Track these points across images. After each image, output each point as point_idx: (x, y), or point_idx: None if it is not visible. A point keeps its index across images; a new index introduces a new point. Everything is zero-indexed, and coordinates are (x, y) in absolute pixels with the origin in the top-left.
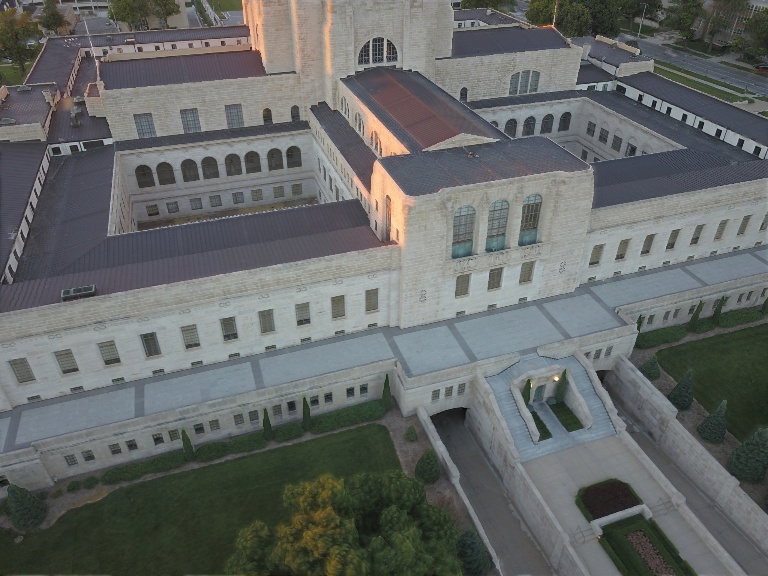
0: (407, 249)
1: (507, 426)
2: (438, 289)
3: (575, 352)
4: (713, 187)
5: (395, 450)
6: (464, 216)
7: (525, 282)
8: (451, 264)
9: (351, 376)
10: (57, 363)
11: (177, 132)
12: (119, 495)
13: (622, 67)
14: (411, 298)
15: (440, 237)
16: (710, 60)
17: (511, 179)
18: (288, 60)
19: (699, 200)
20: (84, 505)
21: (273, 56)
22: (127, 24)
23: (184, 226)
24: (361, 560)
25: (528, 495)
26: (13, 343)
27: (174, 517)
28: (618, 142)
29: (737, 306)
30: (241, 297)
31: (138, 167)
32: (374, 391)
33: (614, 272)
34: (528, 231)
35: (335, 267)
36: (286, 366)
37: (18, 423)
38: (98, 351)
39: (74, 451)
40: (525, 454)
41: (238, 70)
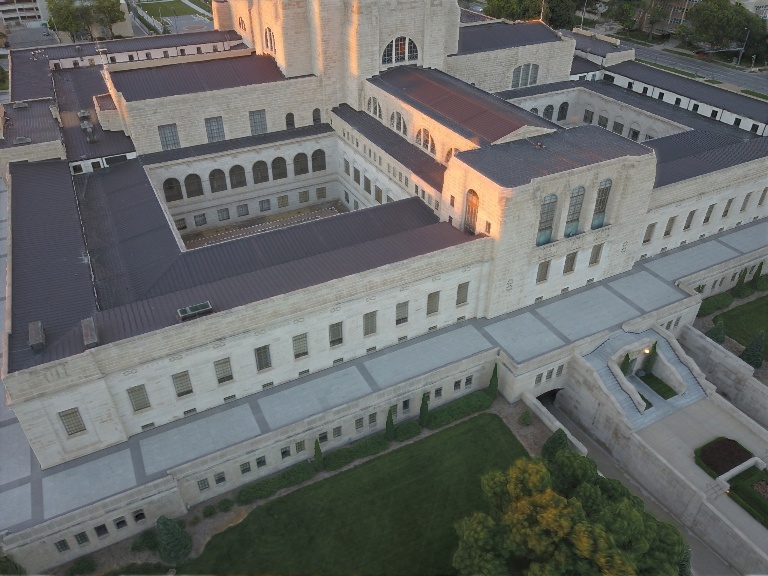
0: (501, 240)
1: (616, 400)
2: (523, 277)
3: (653, 325)
4: (742, 163)
5: (514, 436)
6: (547, 204)
7: (593, 264)
8: (536, 252)
9: (459, 369)
10: (173, 386)
11: (201, 142)
12: (260, 514)
13: (608, 57)
14: (499, 288)
15: (529, 226)
16: (653, 48)
17: (589, 166)
18: (306, 63)
19: (732, 175)
20: (227, 529)
21: (292, 59)
22: (69, 34)
23: (257, 236)
24: (606, 534)
25: (650, 462)
26: (135, 370)
27: (325, 528)
28: (619, 128)
29: (767, 270)
30: (351, 301)
31: (166, 180)
32: (477, 382)
33: (661, 248)
34: (597, 215)
35: (435, 263)
36: (393, 366)
37: (140, 453)
38: (214, 370)
39: (207, 475)
40: (635, 425)
41: (255, 75)
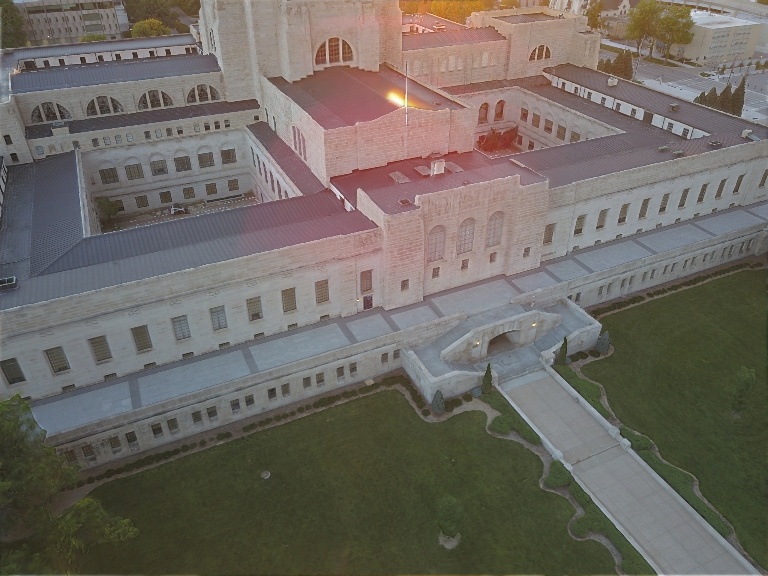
0: None
1: None
2: None
3: None
4: None
5: None
6: None
7: None
8: None
9: None
10: None
11: None
12: None
13: (358, 194)
14: None
15: None
16: None
17: None
18: None
19: None
20: None
21: None
22: None
23: None
24: None
25: None
26: None
27: None
28: None
29: None
30: None
31: None
32: None
33: None
34: None
35: None
36: None
37: None
38: None
39: None
40: None
41: None
